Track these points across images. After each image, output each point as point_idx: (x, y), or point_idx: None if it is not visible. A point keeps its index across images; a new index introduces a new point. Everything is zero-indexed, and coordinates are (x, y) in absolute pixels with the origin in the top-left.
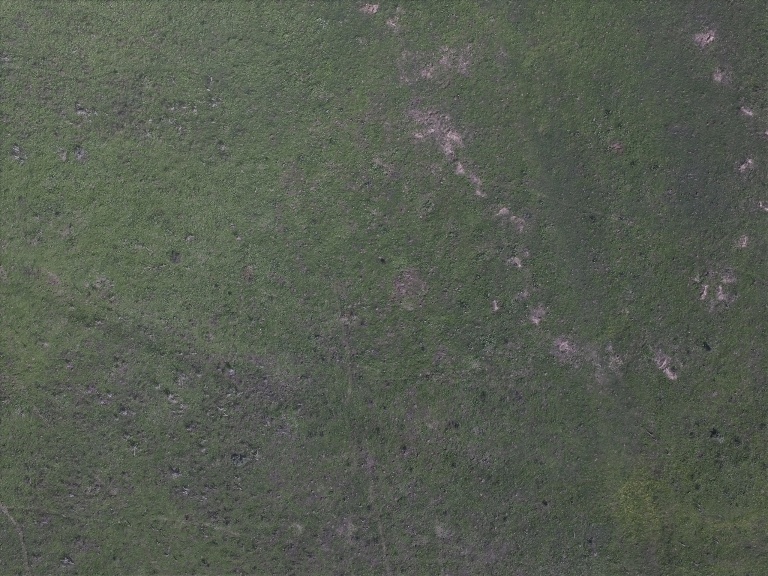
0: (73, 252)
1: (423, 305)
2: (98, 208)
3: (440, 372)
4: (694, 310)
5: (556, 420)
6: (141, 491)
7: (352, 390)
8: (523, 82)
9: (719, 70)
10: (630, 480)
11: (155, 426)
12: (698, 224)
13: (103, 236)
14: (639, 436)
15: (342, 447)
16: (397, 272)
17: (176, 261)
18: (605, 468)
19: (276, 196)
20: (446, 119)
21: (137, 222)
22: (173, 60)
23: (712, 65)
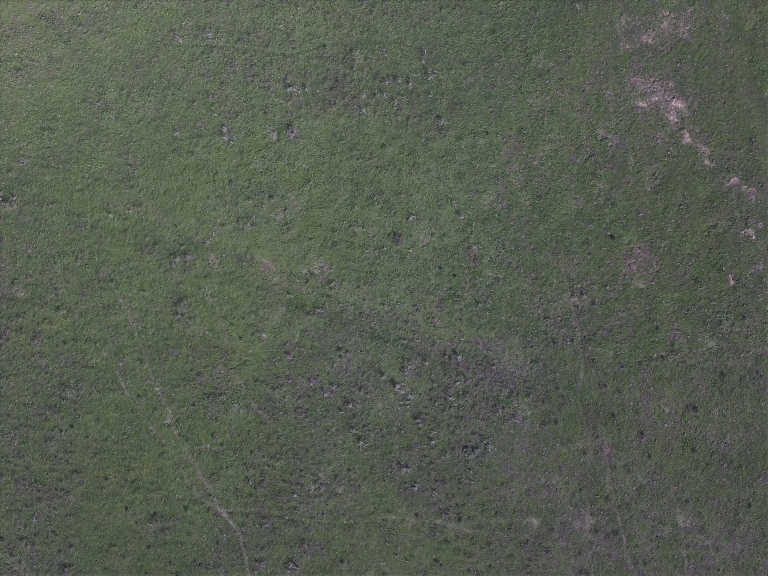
0: (289, 237)
1: (655, 282)
2: (314, 190)
3: (676, 352)
4: None
5: None
6: (367, 488)
7: (584, 374)
8: (746, 46)
9: None
10: None
11: (381, 419)
12: None
13: (320, 219)
14: None
15: (577, 434)
16: (627, 248)
17: (399, 243)
18: None
19: (498, 172)
20: (670, 86)
21: (356, 203)
22: (384, 32)
23: None
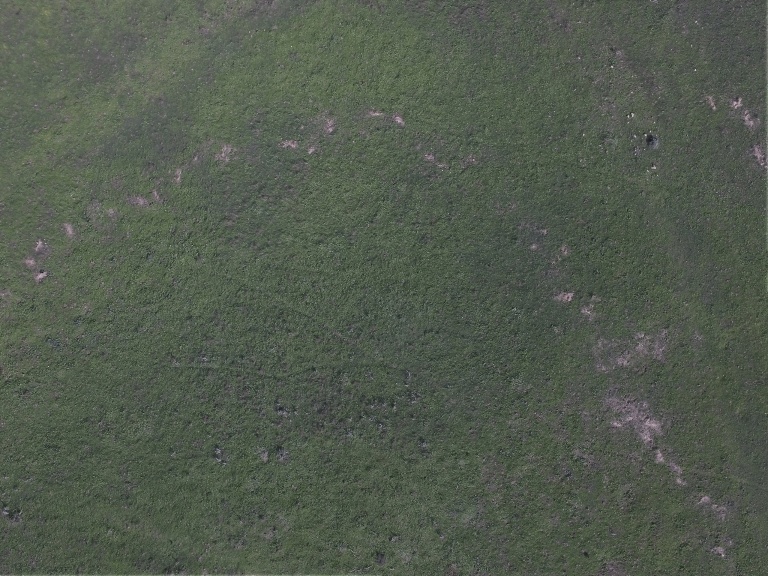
0: (277, 555)
1: None
2: (301, 510)
3: None
4: None
5: None
6: None
7: None
8: (718, 365)
9: None
10: None
11: None
12: None
13: (307, 538)
14: None
15: None
16: (600, 565)
17: (381, 563)
18: None
19: (477, 491)
20: (644, 406)
21: (341, 524)
22: (370, 355)
23: None
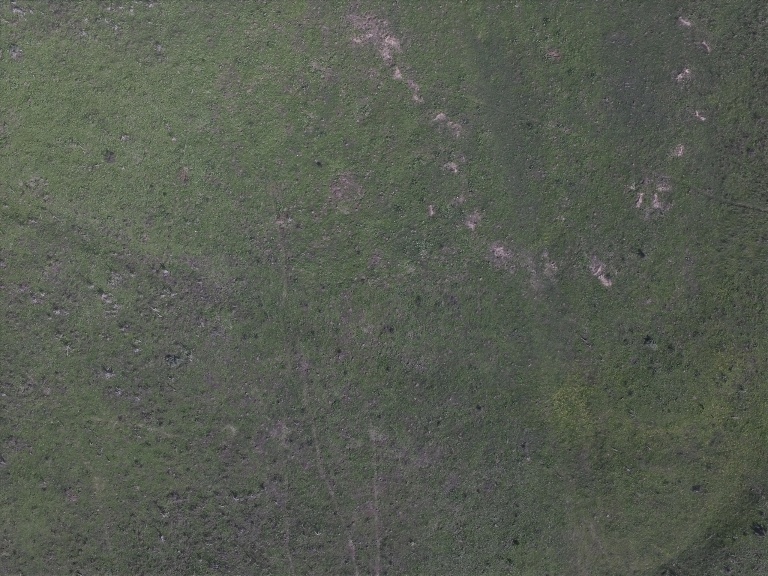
0: (7, 150)
1: (359, 209)
2: (32, 107)
3: (375, 276)
4: (629, 217)
5: (491, 325)
6: (74, 391)
7: (287, 293)
8: None
9: None
10: (564, 386)
11: (88, 326)
12: (635, 132)
13: (37, 135)
14: (573, 342)
15: (276, 349)
16: (333, 176)
17: (110, 160)
18: (539, 374)
19: (212, 98)
20: (384, 24)
21: (72, 121)
22: None
23: None
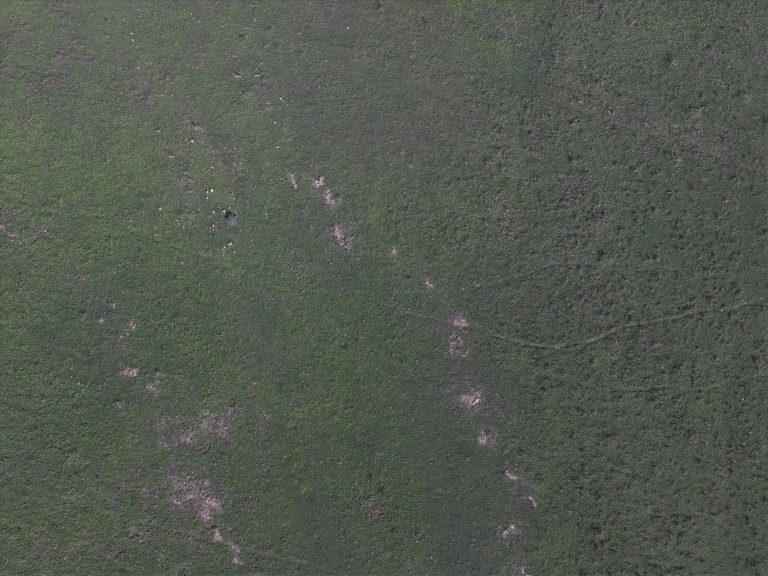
0: None
1: None
2: None
3: None
4: None
5: None
6: None
7: None
8: (286, 444)
9: (484, 433)
10: None
11: None
12: None
13: None
14: None
15: None
16: None
17: None
18: None
19: (28, 566)
20: (205, 484)
21: None
22: None
23: (477, 427)
